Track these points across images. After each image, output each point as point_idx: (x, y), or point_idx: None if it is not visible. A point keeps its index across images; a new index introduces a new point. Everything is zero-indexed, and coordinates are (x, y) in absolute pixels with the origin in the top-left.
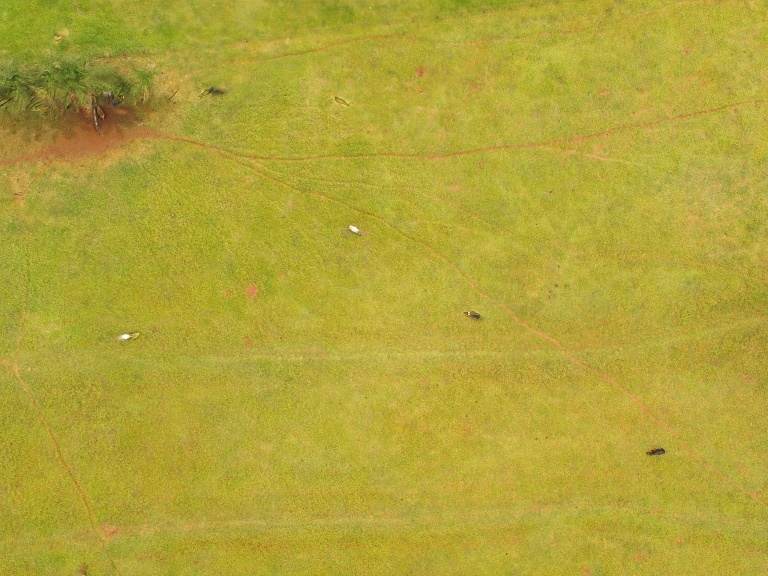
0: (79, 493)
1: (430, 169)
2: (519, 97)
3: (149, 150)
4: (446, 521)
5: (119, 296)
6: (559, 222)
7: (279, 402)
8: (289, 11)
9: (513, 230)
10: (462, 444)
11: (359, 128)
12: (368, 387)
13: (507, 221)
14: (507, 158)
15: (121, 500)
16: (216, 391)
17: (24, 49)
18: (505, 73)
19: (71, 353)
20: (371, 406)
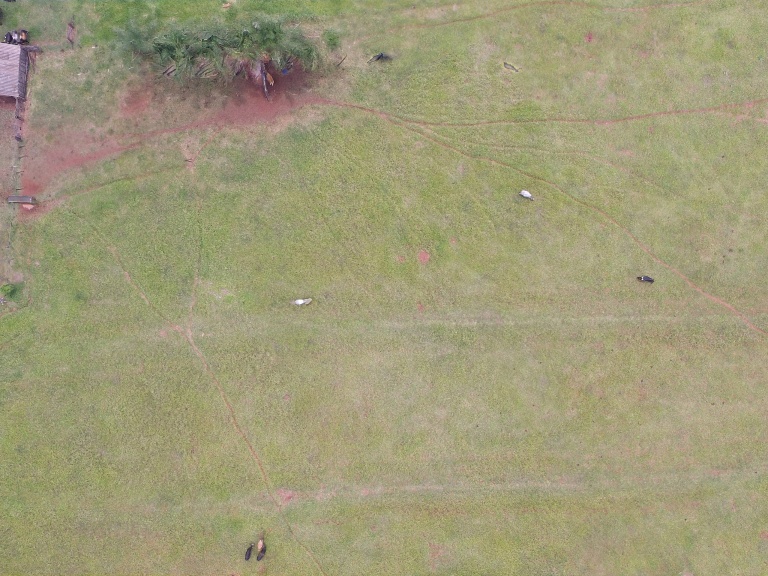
0: (254, 458)
1: (600, 134)
2: (689, 62)
3: (318, 116)
4: (624, 486)
5: (291, 261)
6: (732, 187)
7: (453, 367)
8: None
9: (686, 195)
10: (638, 409)
11: (529, 93)
12: (542, 352)
13: (679, 186)
14: (678, 123)
15: (297, 465)
16: (390, 356)
17: (193, 16)
18: (674, 38)
19: (244, 318)
20: (546, 371)
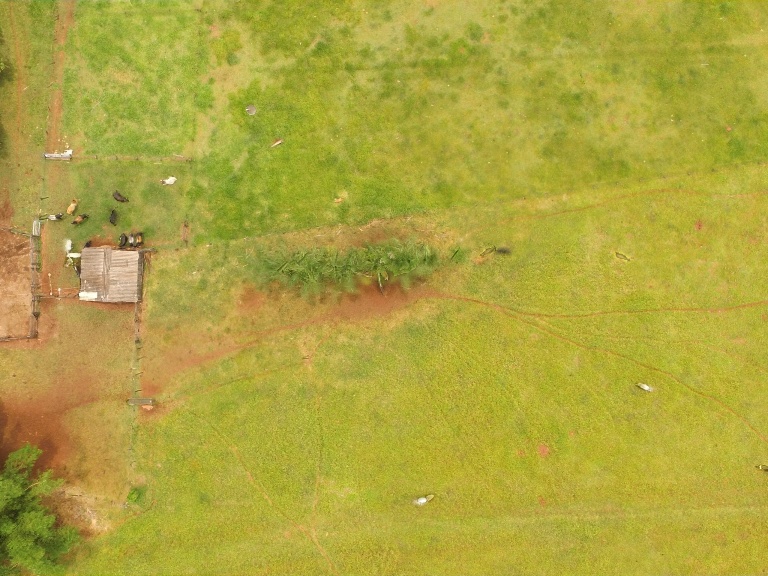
0: None
1: (714, 323)
2: None
3: (433, 310)
4: None
5: (412, 458)
6: None
7: (576, 561)
8: (564, 167)
9: None
10: None
11: (642, 284)
12: (664, 544)
13: None
14: None
15: None
16: (513, 551)
17: (306, 213)
18: None
19: (368, 517)
20: (668, 563)
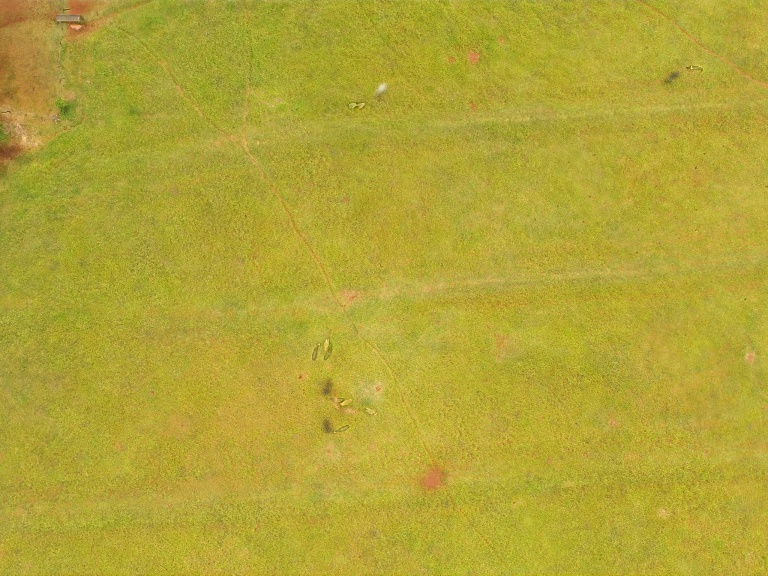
0: (316, 261)
1: None
2: None
3: None
4: (684, 270)
5: (343, 67)
6: None
7: (509, 163)
8: None
9: None
10: (694, 195)
11: None
12: (596, 144)
13: None
14: None
15: (358, 266)
16: (445, 156)
17: None
18: None
19: (299, 125)
20: (600, 163)
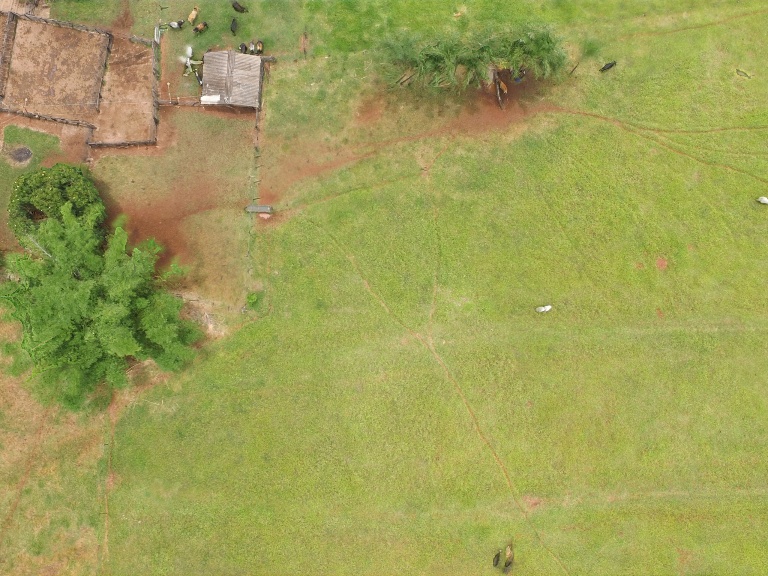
0: (499, 465)
1: None
2: None
3: (552, 124)
4: None
5: (530, 269)
6: None
7: (695, 373)
8: None
9: None
10: None
11: (763, 100)
12: None
13: None
14: None
15: (542, 472)
16: (631, 363)
17: (426, 26)
18: None
19: (485, 326)
20: None
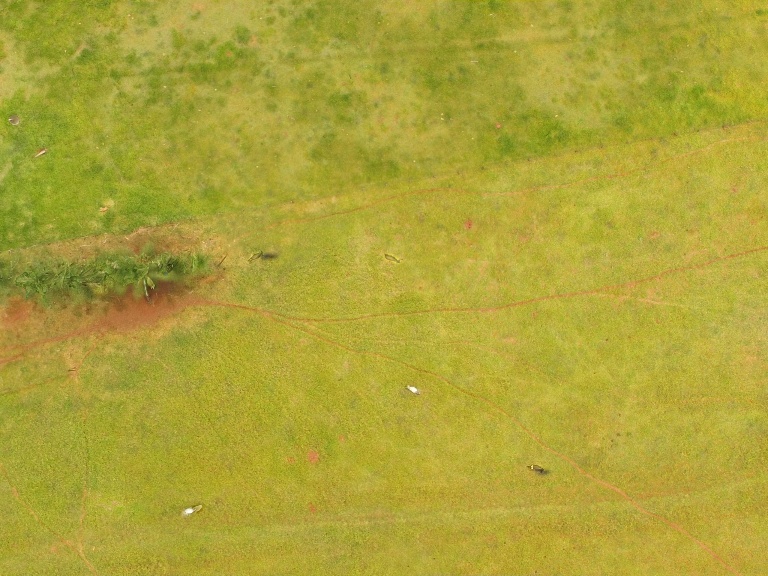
0: None
1: (484, 322)
2: (569, 244)
3: (201, 318)
4: None
5: (180, 469)
6: (617, 370)
7: (347, 568)
8: (333, 169)
9: (571, 381)
10: None
11: (411, 285)
12: (435, 548)
13: (565, 372)
14: (561, 307)
15: None
16: (283, 560)
17: (70, 223)
18: (554, 221)
19: (135, 530)
20: (439, 567)
